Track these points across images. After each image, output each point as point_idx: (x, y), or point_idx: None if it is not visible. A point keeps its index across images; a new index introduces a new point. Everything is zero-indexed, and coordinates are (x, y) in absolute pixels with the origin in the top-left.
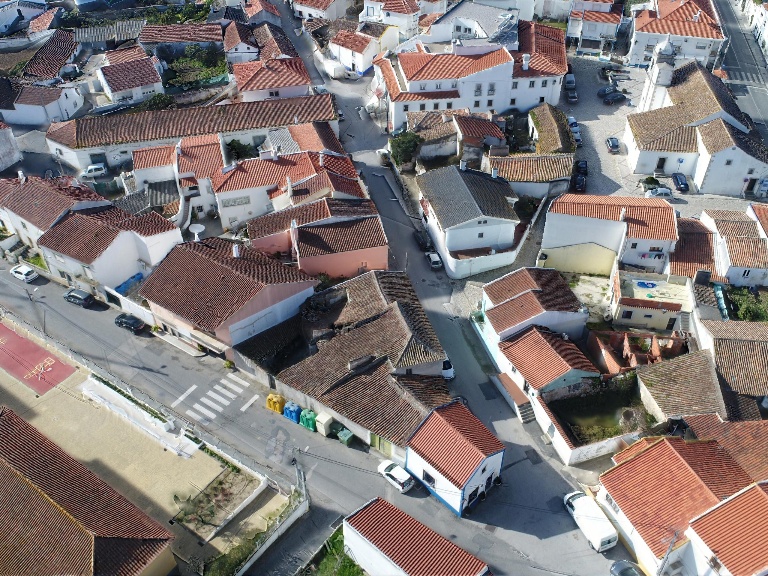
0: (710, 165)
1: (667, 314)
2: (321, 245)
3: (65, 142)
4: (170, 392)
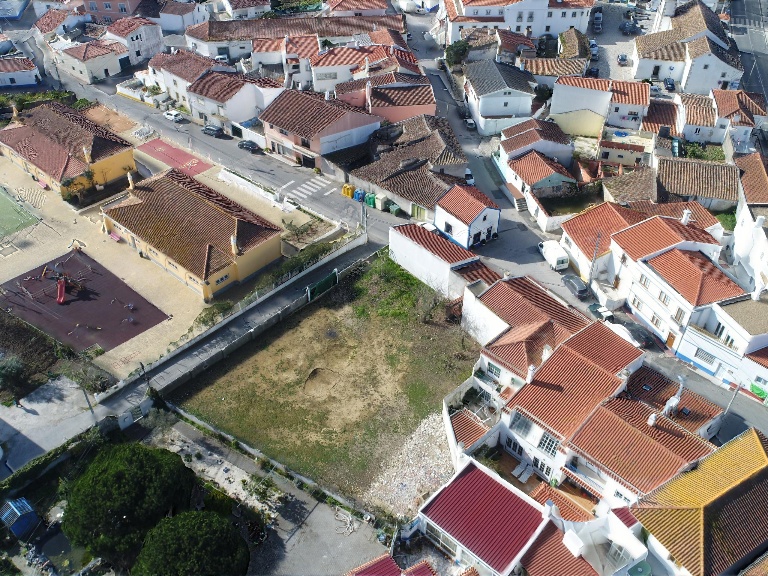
0: (691, 69)
1: (634, 154)
2: (387, 100)
3: (200, 37)
4: (276, 183)
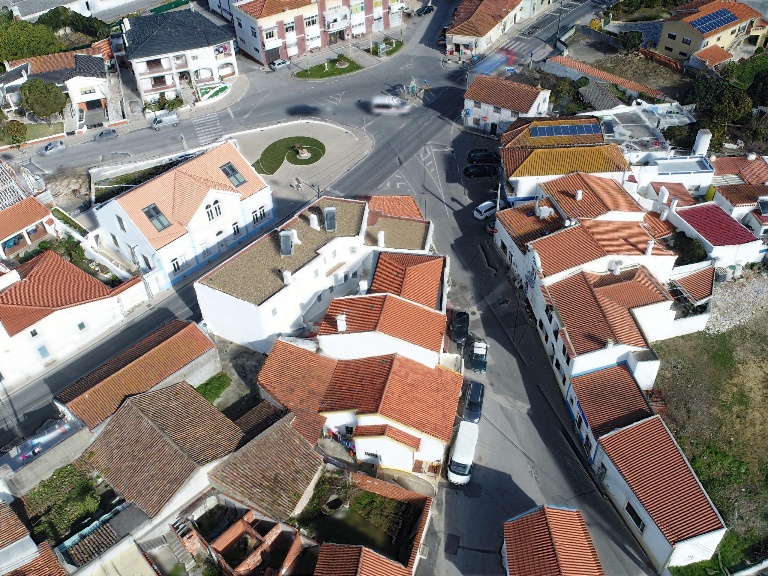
0: None
1: None
2: None
3: None
4: None
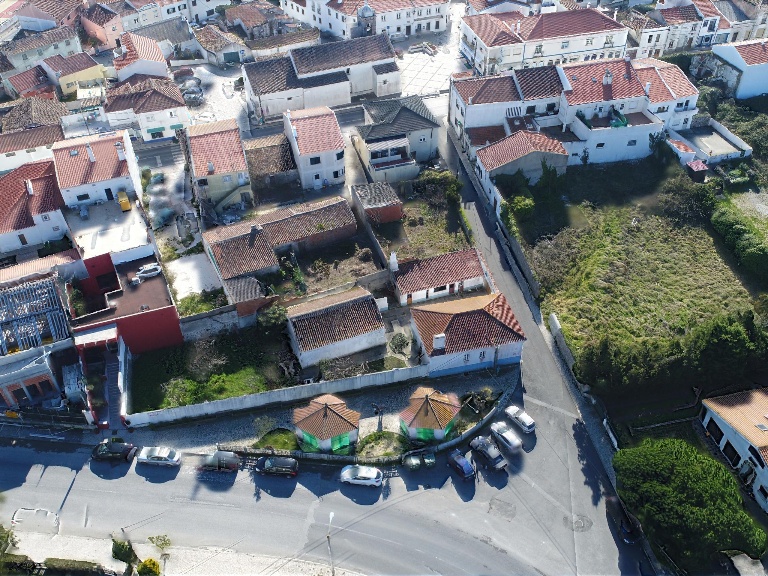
0: None
1: None
2: None
3: None
4: (8, 37)
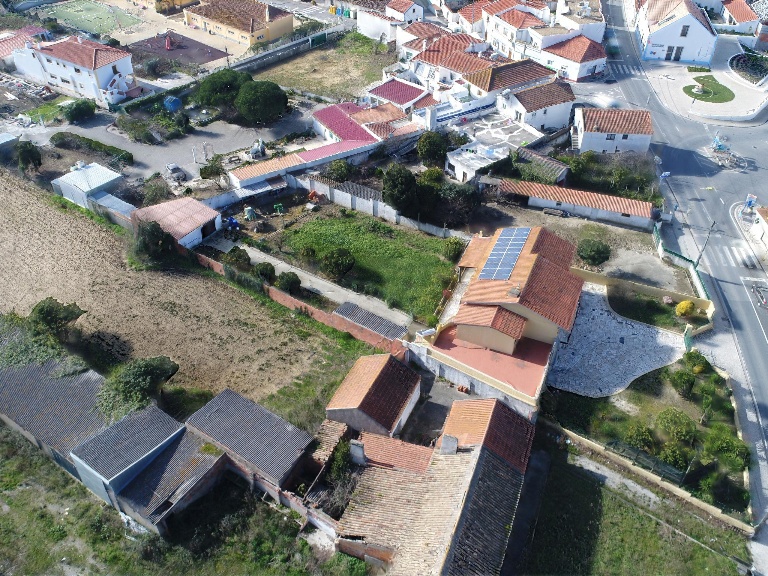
0: None
1: None
2: None
3: None
4: None
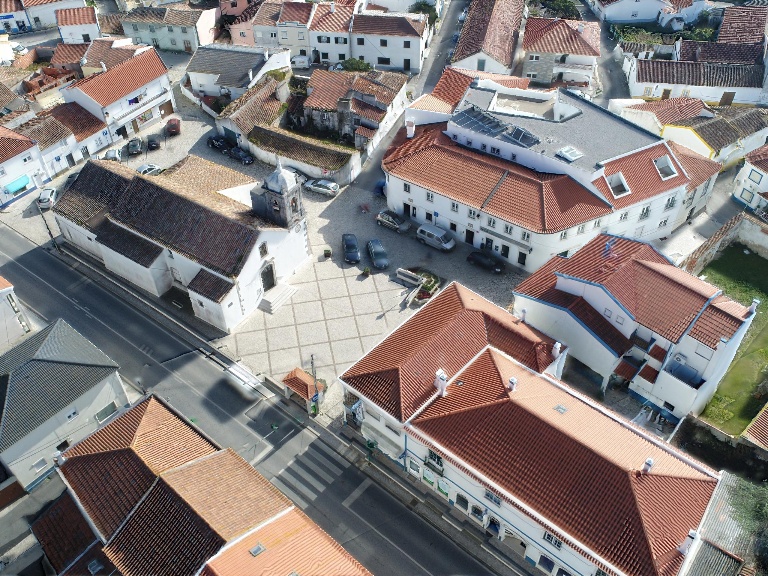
0: None
1: None
2: None
3: None
4: None
